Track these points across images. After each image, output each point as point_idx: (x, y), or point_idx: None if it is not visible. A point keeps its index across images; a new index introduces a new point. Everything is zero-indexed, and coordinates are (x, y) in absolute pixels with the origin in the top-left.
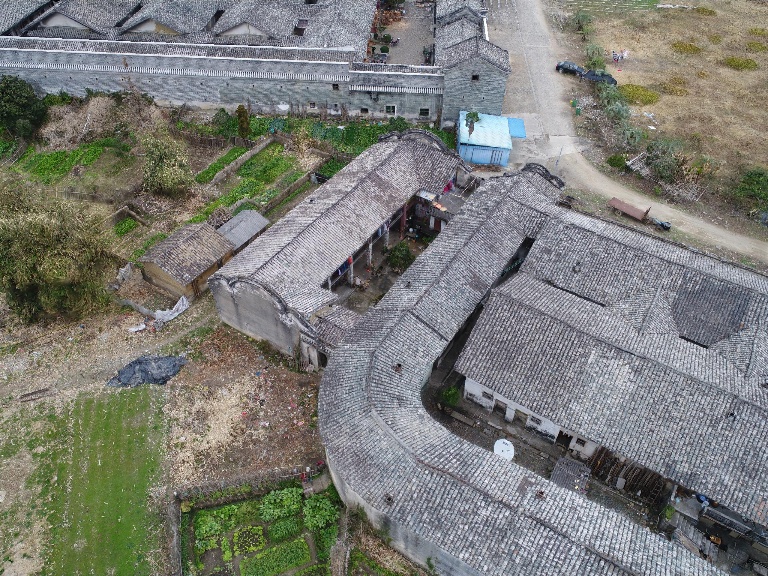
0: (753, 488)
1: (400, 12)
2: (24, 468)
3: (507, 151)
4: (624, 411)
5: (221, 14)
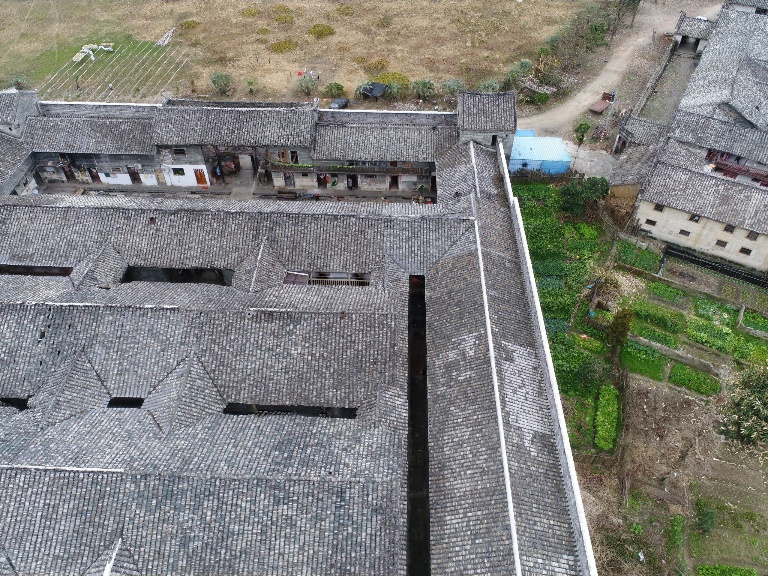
0: None
1: None
2: None
3: None
4: None
5: None
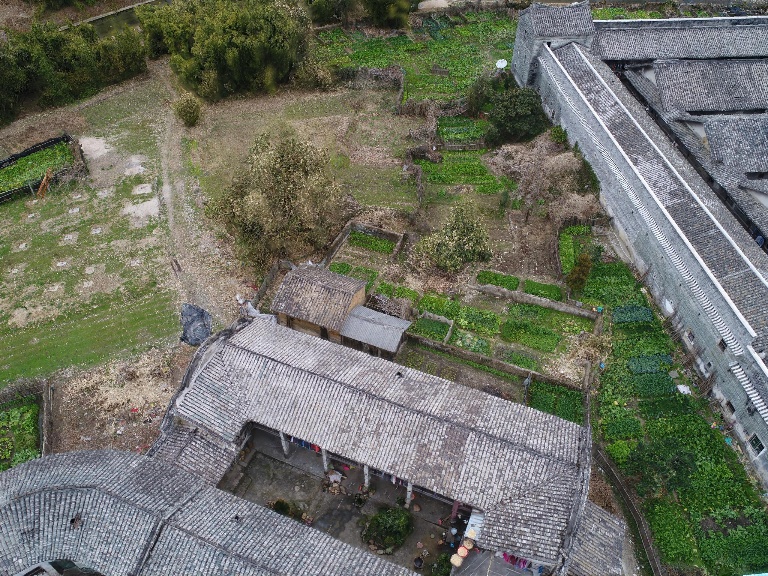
0: None
1: None
2: (108, 287)
3: None
4: None
5: None
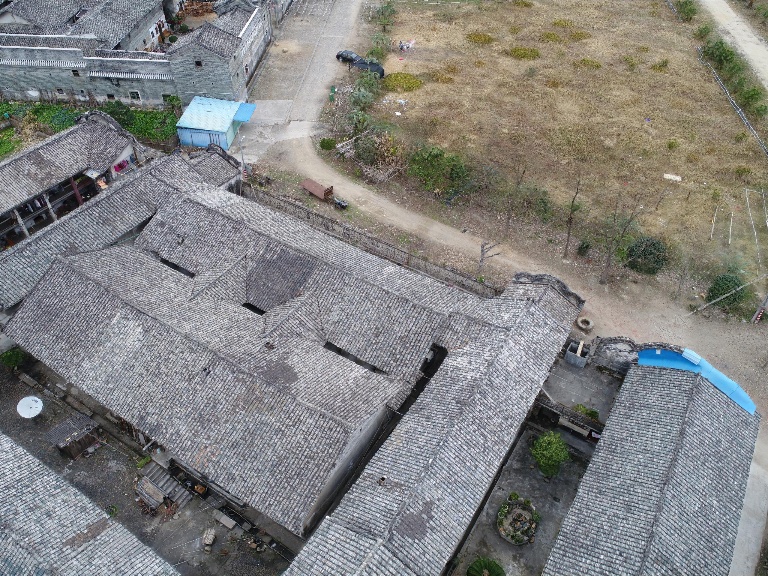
0: (201, 437)
1: None
2: None
3: (223, 134)
4: (123, 368)
5: None
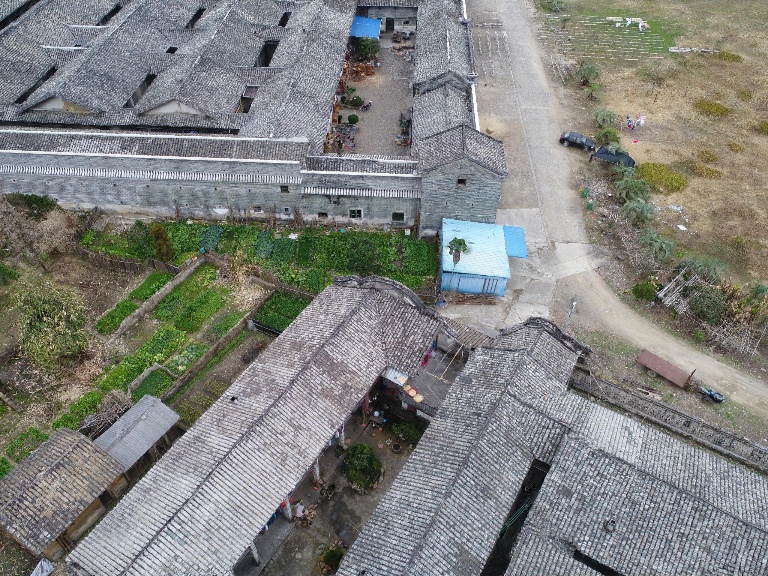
0: None
1: (374, 64)
2: None
3: (503, 279)
4: None
5: (154, 78)
